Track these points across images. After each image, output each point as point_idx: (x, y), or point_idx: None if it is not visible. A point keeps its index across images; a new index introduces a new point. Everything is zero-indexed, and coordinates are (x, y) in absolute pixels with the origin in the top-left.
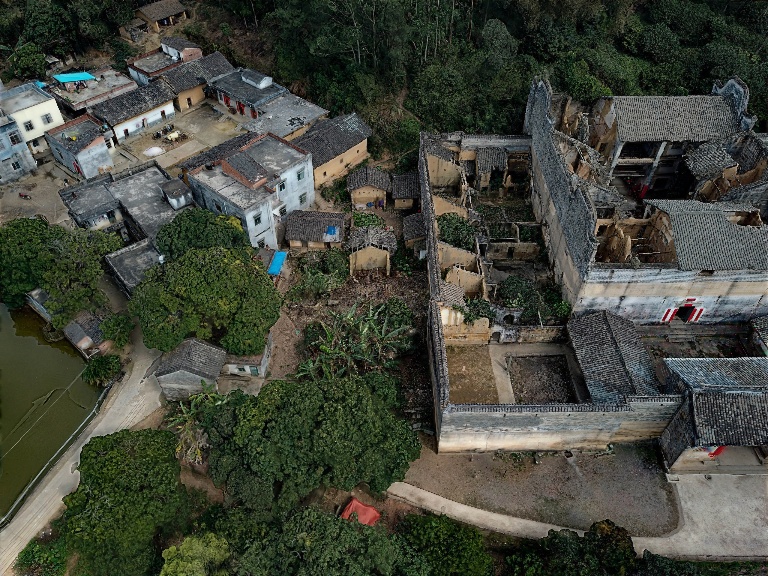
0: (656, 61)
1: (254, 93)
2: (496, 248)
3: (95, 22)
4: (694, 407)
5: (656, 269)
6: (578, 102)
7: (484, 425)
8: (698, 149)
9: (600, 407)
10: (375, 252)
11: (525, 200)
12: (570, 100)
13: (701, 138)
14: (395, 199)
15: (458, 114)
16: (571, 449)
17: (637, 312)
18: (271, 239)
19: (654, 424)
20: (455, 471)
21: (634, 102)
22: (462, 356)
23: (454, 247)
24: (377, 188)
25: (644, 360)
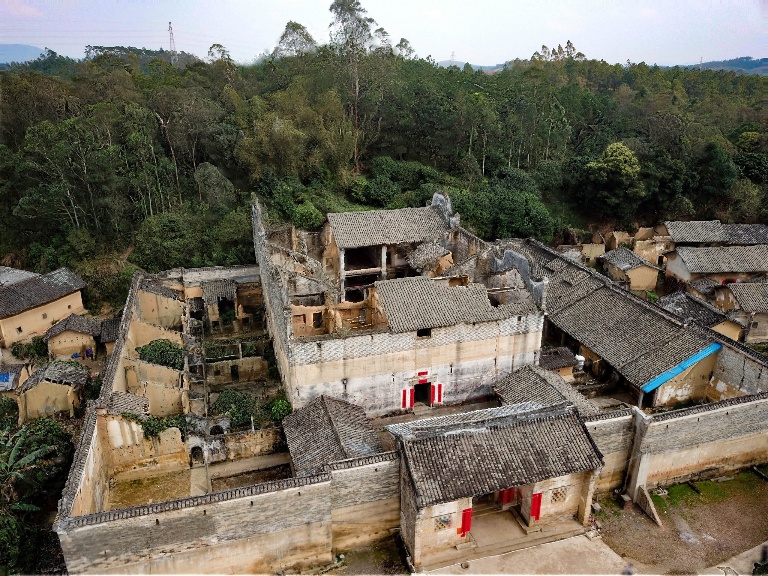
0: (384, 206)
1: None
2: (215, 369)
3: None
4: (408, 458)
5: (367, 336)
6: (304, 231)
7: (134, 547)
8: (416, 249)
9: (289, 482)
10: (52, 389)
11: (263, 330)
12: (293, 229)
13: (416, 239)
14: (105, 344)
15: (184, 257)
16: (284, 571)
17: (370, 400)
18: None
19: (382, 506)
20: None
21: (348, 217)
22: (151, 488)
23: (148, 363)
24: (80, 333)
25: (370, 439)
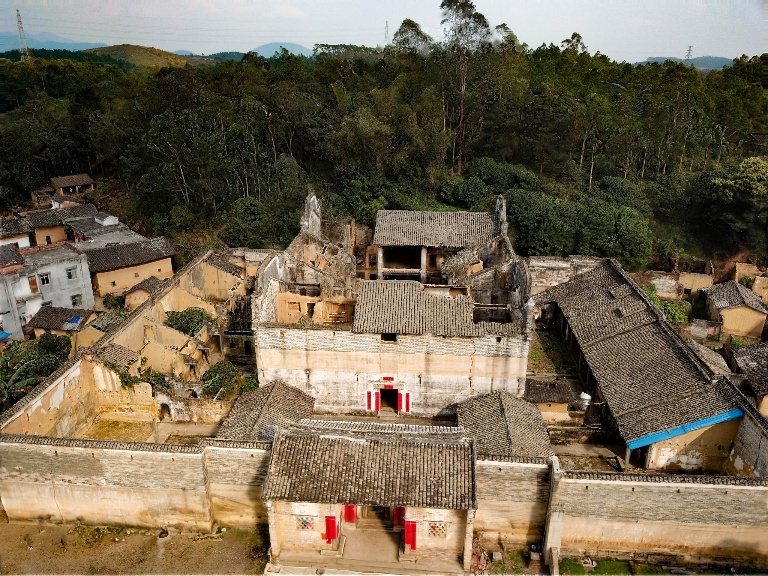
0: None
1: (96, 228)
2: (231, 341)
3: (5, 184)
4: (274, 451)
5: (329, 331)
6: (364, 226)
7: (40, 470)
8: (456, 255)
9: (164, 446)
10: (96, 334)
11: None
12: (353, 222)
13: (457, 244)
14: None
15: (257, 238)
16: (167, 527)
17: (333, 394)
18: (13, 325)
19: None
20: (12, 541)
21: (397, 215)
22: (121, 430)
23: (164, 325)
24: (150, 293)
25: None
